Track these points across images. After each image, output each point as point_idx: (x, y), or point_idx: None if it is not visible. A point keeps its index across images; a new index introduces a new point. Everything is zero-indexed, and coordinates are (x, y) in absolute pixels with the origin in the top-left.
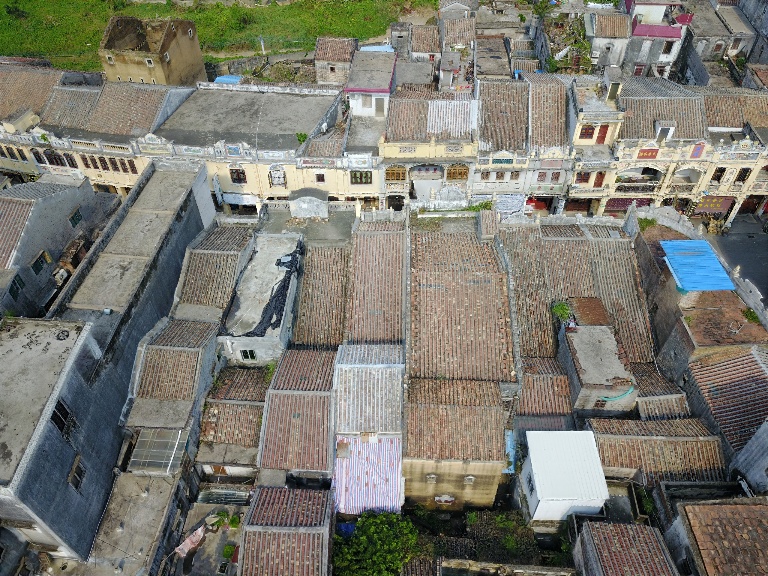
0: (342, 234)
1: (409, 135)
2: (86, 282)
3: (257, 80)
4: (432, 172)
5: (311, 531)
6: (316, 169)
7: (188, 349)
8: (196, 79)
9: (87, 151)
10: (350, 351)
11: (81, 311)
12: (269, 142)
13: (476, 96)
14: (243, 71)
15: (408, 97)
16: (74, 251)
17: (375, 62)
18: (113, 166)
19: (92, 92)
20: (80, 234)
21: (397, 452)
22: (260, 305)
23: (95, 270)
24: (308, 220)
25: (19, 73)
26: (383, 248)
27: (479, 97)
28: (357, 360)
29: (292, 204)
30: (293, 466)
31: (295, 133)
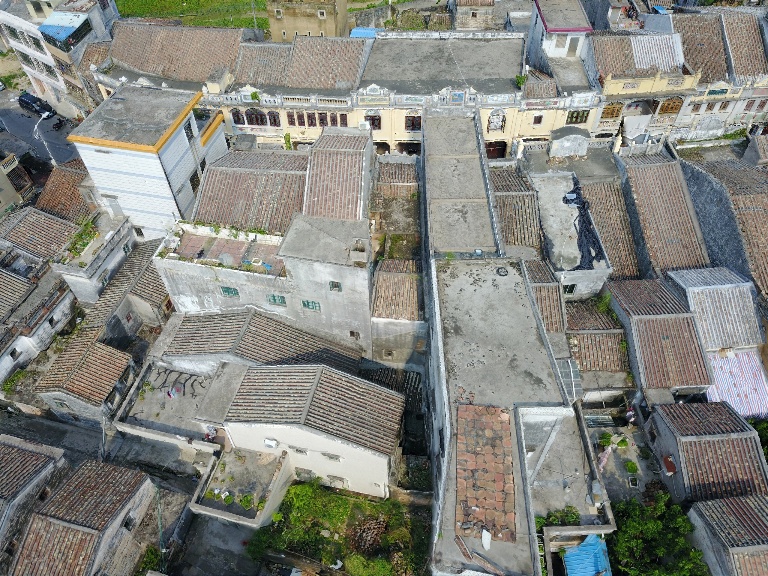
0: (608, 170)
1: (620, 72)
2: (434, 227)
3: (401, 30)
4: (633, 108)
5: (742, 436)
6: (537, 111)
7: (547, 284)
8: (345, 31)
9: (300, 107)
10: (684, 276)
11: (449, 254)
12: (482, 87)
13: (666, 30)
14: (370, 22)
15: (601, 35)
16: (381, 201)
17: (559, 1)
18: (321, 121)
19: (282, 47)
20: (371, 185)
21: (756, 364)
22: (572, 241)
23: (434, 215)
24: (567, 159)
25: (193, 32)
26: (660, 179)
27: (674, 31)
28: (700, 283)
29: (555, 143)
30: (677, 384)
31: (502, 77)
